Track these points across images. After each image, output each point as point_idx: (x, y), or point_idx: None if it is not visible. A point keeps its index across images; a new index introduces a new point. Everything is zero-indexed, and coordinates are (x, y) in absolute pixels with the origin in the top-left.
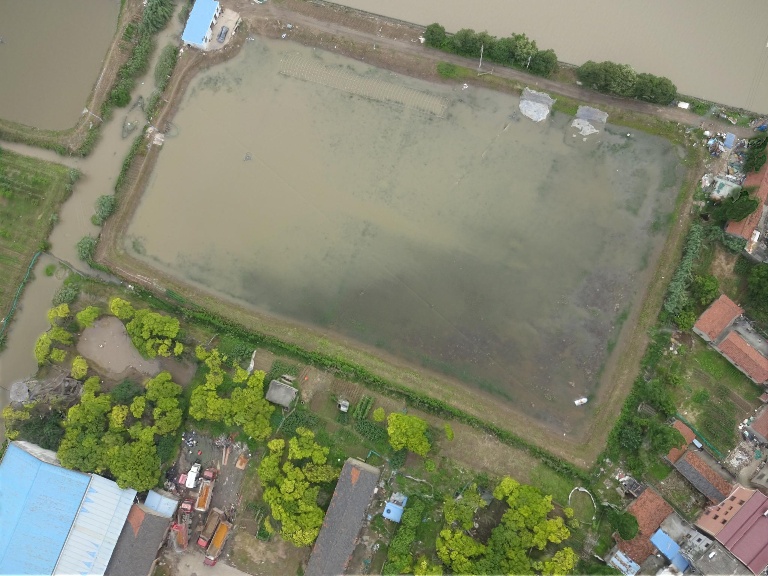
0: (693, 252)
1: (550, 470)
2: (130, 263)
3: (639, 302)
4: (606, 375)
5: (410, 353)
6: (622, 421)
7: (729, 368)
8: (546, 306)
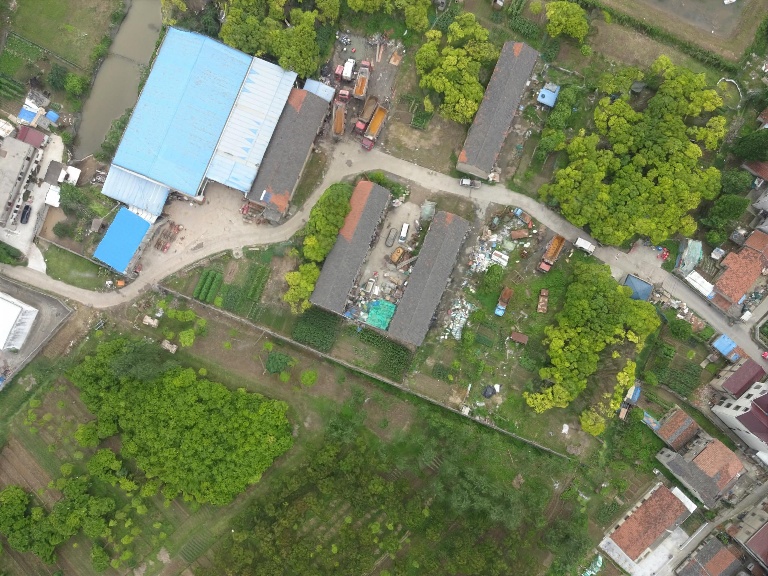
0: None
1: (698, 63)
2: None
3: None
4: None
5: None
6: None
7: None
8: None
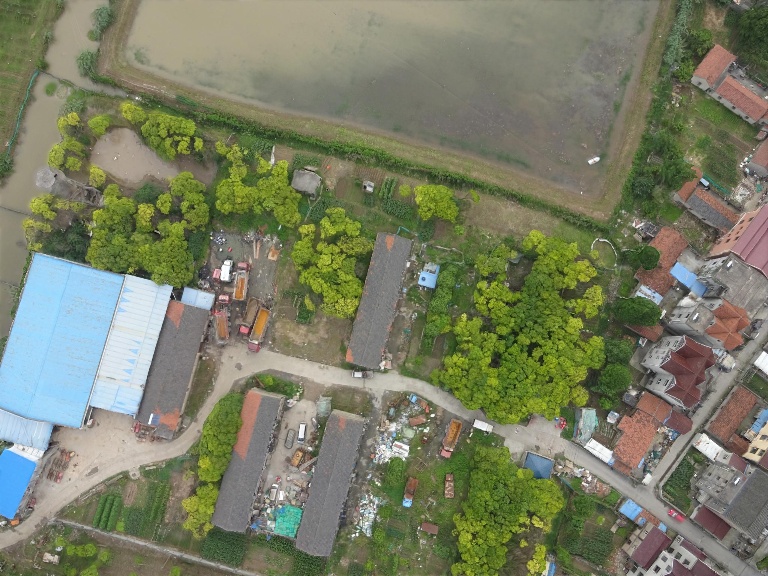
0: (687, 7)
1: (571, 226)
2: (135, 74)
3: (640, 63)
4: (615, 134)
5: (427, 133)
6: (634, 173)
7: (727, 114)
8: (553, 76)
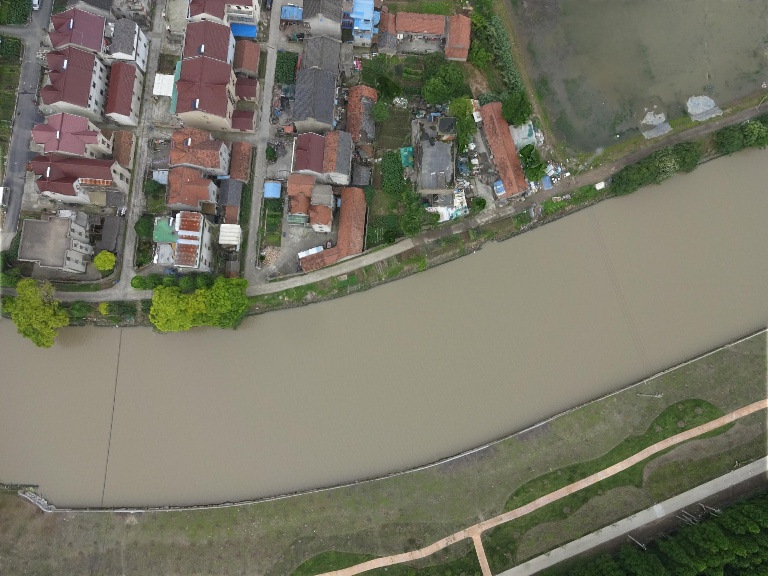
0: (511, 70)
1: None
2: None
3: (513, 19)
4: None
5: None
6: None
7: None
8: None
